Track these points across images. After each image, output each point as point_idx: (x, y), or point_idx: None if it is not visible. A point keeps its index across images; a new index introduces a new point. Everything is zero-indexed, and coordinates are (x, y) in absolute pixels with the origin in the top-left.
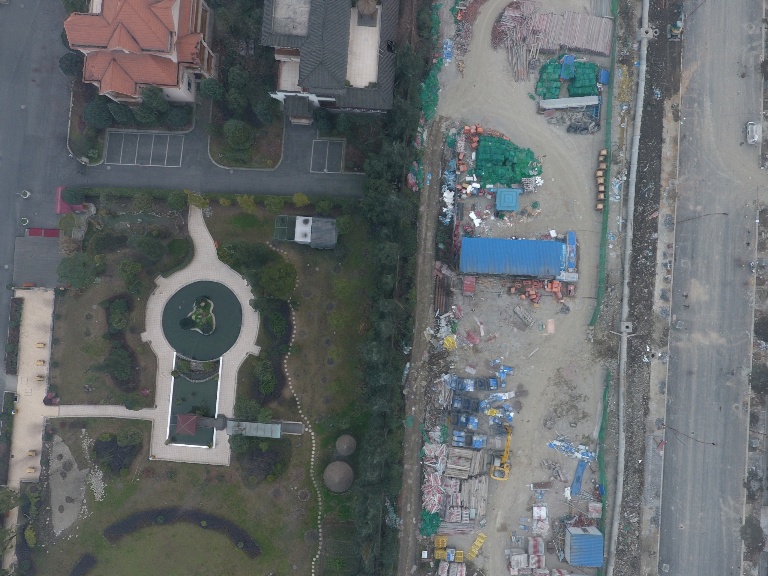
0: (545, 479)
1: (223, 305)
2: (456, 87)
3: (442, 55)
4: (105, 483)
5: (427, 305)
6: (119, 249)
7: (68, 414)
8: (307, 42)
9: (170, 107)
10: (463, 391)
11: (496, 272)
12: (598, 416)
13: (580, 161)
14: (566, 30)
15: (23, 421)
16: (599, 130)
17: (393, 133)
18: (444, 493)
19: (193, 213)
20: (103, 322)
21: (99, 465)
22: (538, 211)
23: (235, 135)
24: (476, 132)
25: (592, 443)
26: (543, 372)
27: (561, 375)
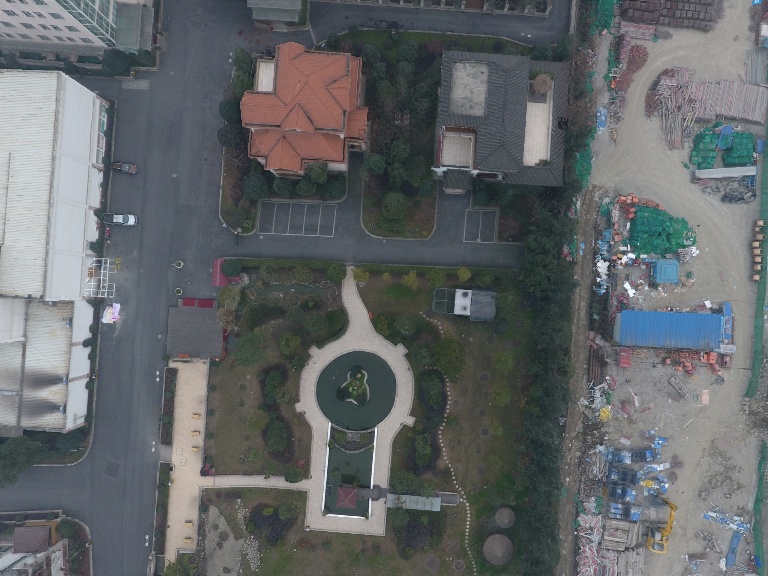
0: (700, 550)
1: (377, 375)
2: (609, 156)
3: (595, 123)
4: (261, 553)
5: (581, 375)
6: (273, 319)
7: (223, 484)
8: (485, 123)
9: (327, 178)
10: (620, 463)
11: (656, 345)
12: (753, 487)
13: (734, 231)
14: (722, 99)
15: (178, 491)
16: (754, 200)
17: (549, 204)
18: (600, 564)
19: (346, 283)
20: (257, 392)
21: (255, 535)
22: (692, 281)
23: (396, 209)
24: (631, 202)
25: (747, 514)
26: (698, 443)
27: (716, 446)
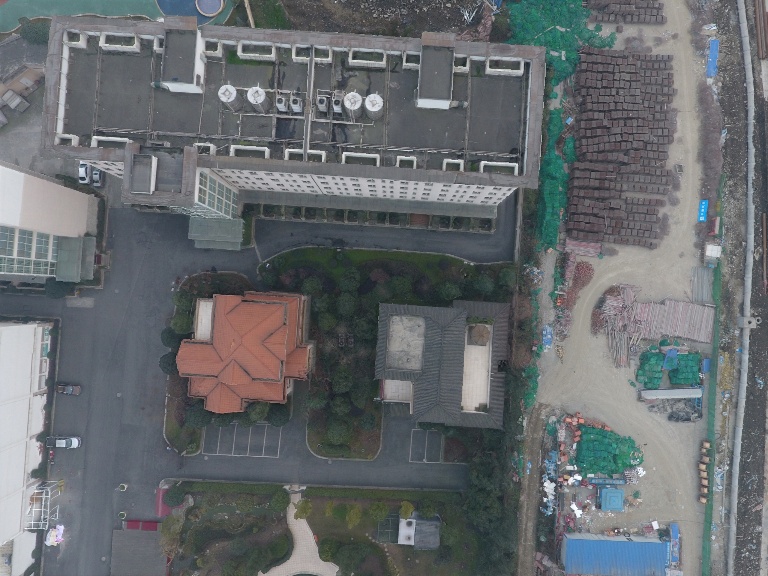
0: None
1: None
2: (555, 373)
3: (541, 341)
4: None
5: None
6: (217, 542)
7: None
8: (422, 378)
9: (270, 405)
10: None
11: (601, 574)
12: None
13: (681, 449)
14: (668, 319)
15: None
16: (701, 419)
17: None
18: None
19: (291, 504)
20: None
21: None
22: (639, 501)
23: (339, 441)
24: None
25: None
26: None
27: None
